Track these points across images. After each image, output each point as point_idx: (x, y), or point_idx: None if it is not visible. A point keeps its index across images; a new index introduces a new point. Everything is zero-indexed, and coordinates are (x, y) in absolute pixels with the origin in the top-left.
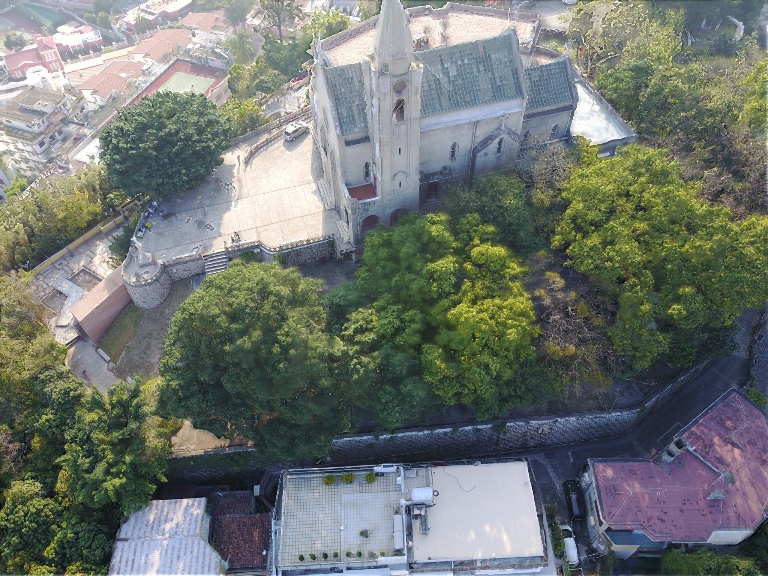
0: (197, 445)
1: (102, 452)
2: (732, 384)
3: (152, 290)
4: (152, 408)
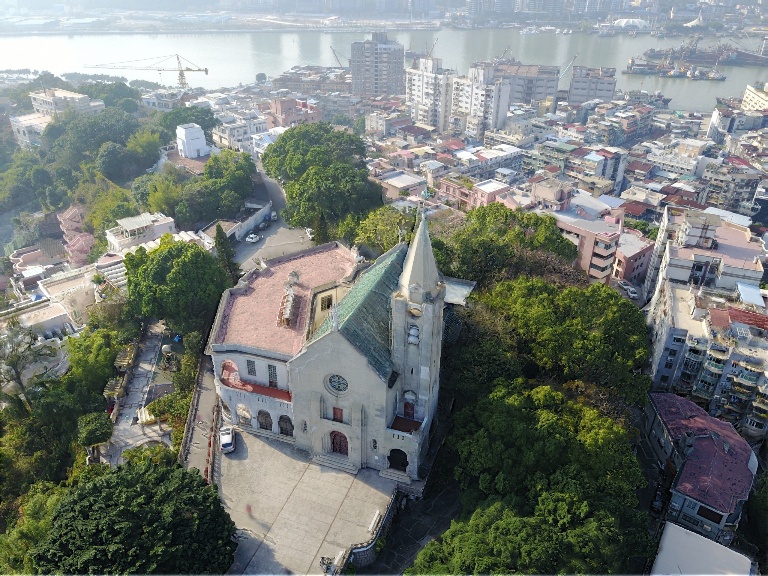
0: None
1: None
2: None
3: None
4: None
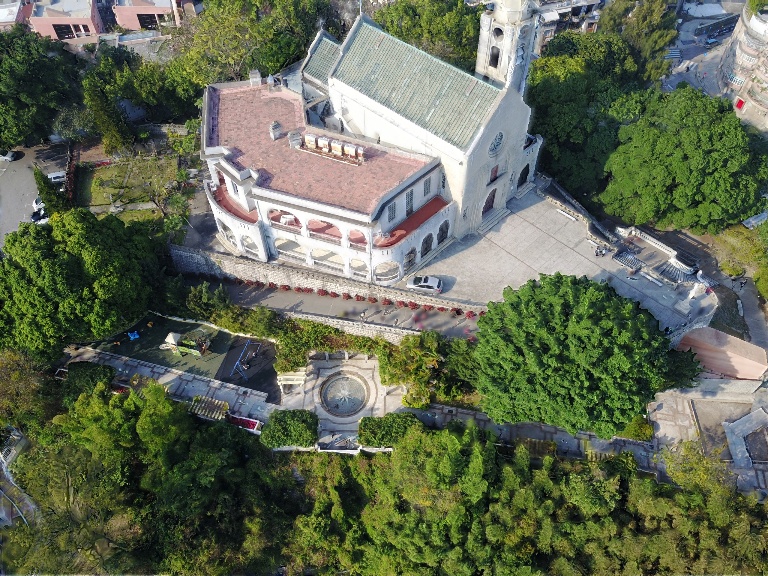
0: None
1: None
2: None
3: None
4: None
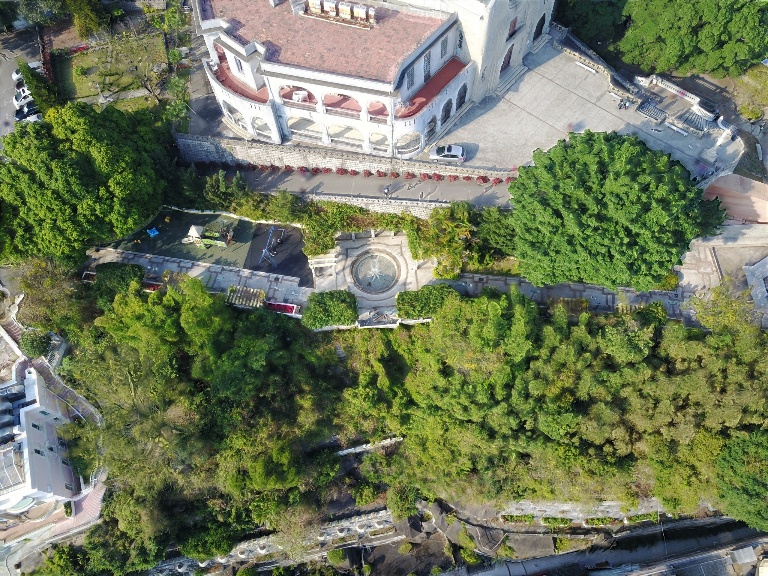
0: None
1: None
2: None
3: None
4: None
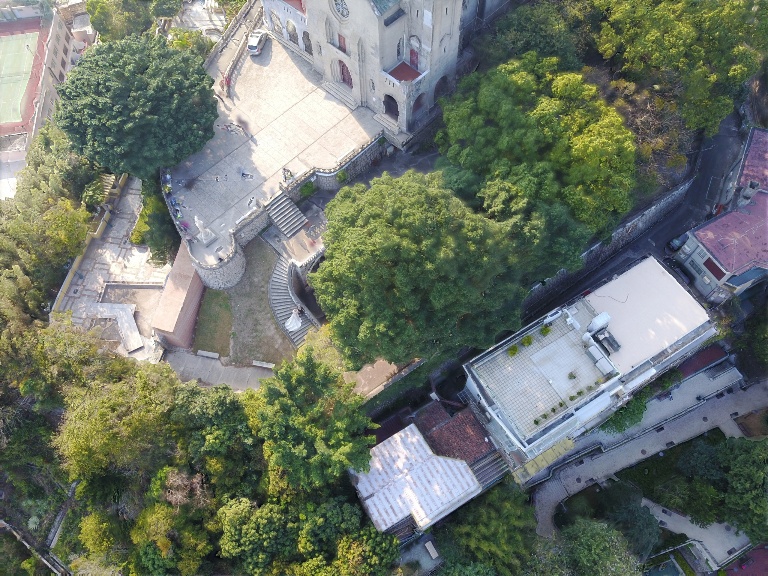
0: (369, 385)
1: (310, 432)
2: (732, 128)
3: (234, 264)
4: (350, 365)
